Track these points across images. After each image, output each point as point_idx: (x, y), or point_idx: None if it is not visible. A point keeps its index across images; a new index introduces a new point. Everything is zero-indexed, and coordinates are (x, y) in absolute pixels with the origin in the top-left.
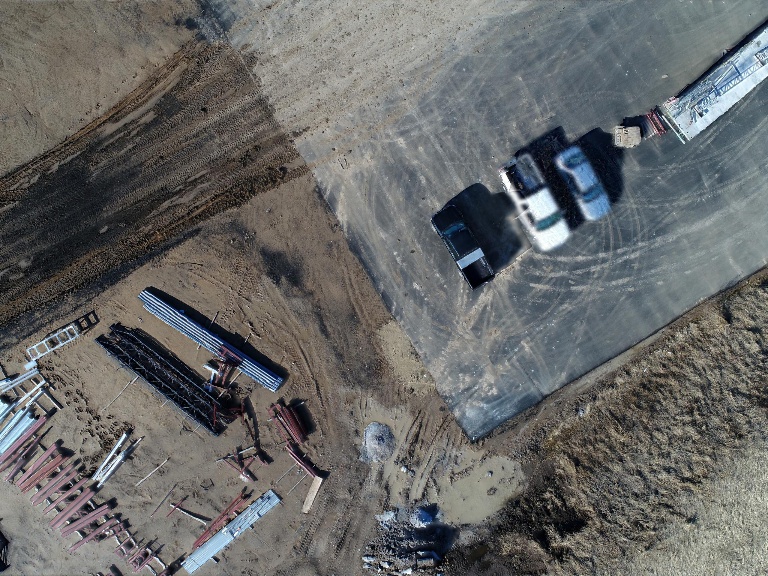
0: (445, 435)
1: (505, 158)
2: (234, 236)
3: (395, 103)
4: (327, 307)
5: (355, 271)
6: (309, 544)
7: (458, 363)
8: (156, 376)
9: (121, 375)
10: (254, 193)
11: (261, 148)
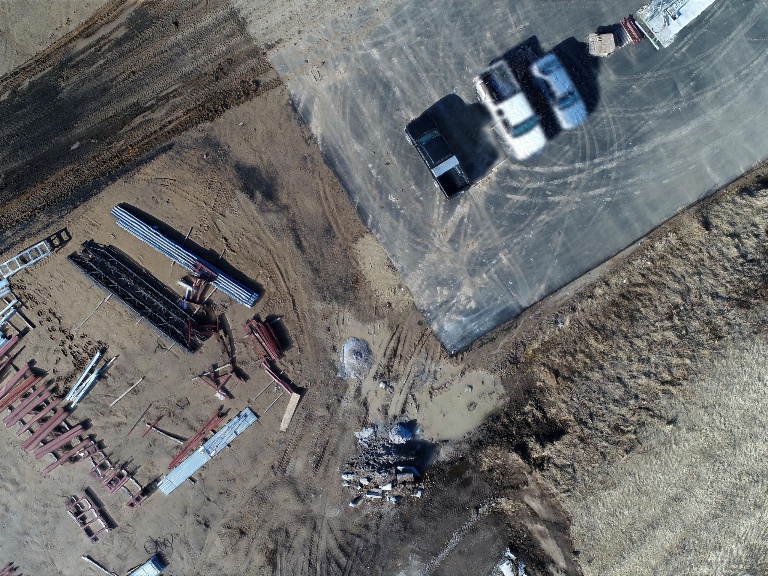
0: (424, 350)
1: (479, 68)
2: (207, 151)
3: (367, 14)
4: (302, 221)
5: (330, 184)
6: (288, 463)
7: (435, 276)
8: (130, 293)
9: (94, 293)
10: (227, 107)
11: (233, 61)
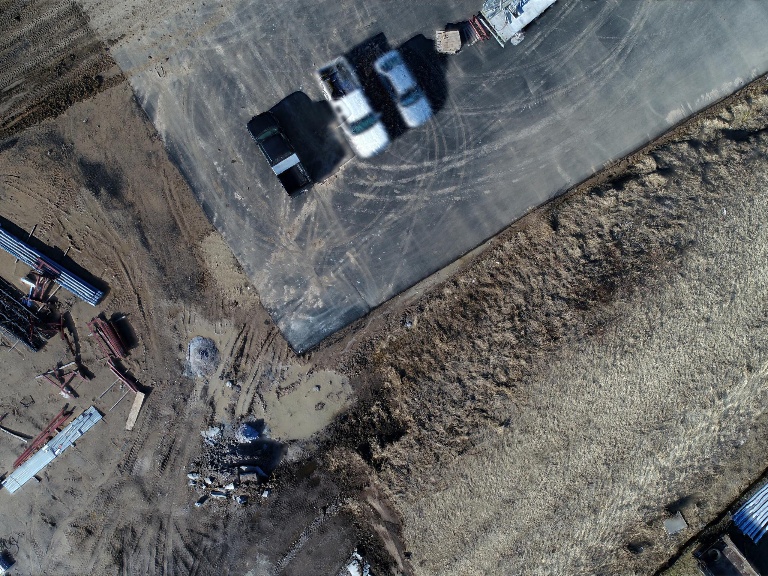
0: (271, 349)
1: (326, 65)
2: (51, 147)
3: (212, 10)
4: (148, 219)
5: (175, 182)
6: (134, 462)
7: (282, 275)
8: None
9: None
10: (70, 103)
11: (76, 57)
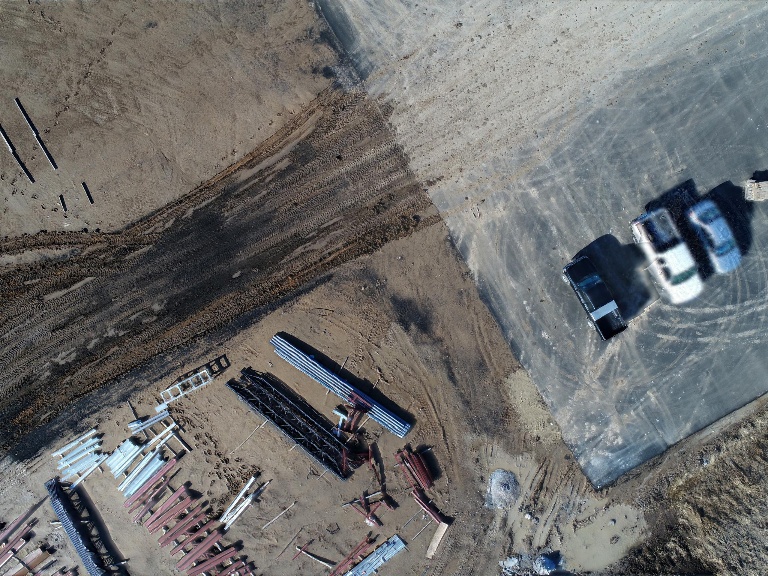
0: (569, 483)
1: (636, 210)
2: (365, 283)
3: (528, 154)
4: (455, 354)
5: (484, 319)
6: None
7: (584, 412)
8: (286, 420)
9: (250, 419)
10: (386, 240)
11: (395, 196)
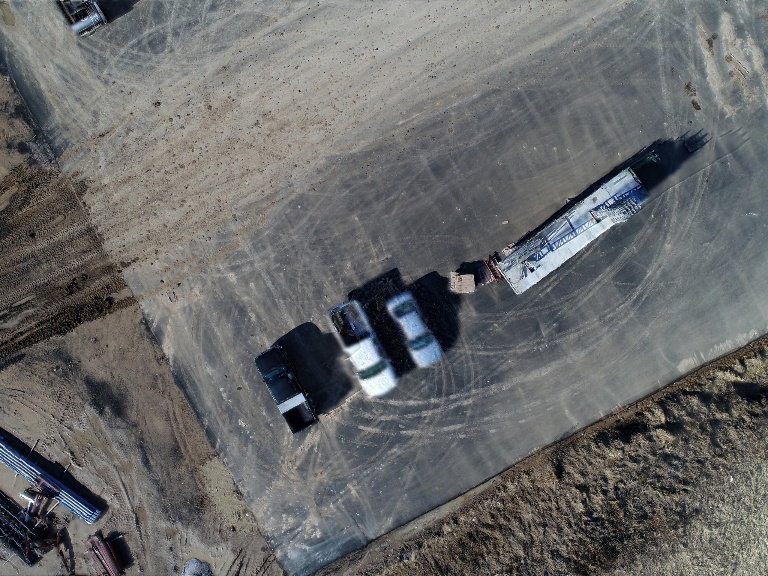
0: (266, 575)
1: (338, 298)
2: (58, 364)
3: (227, 238)
4: (150, 440)
5: (180, 405)
6: None
7: (282, 503)
8: None
9: None
10: (80, 321)
11: (88, 277)
